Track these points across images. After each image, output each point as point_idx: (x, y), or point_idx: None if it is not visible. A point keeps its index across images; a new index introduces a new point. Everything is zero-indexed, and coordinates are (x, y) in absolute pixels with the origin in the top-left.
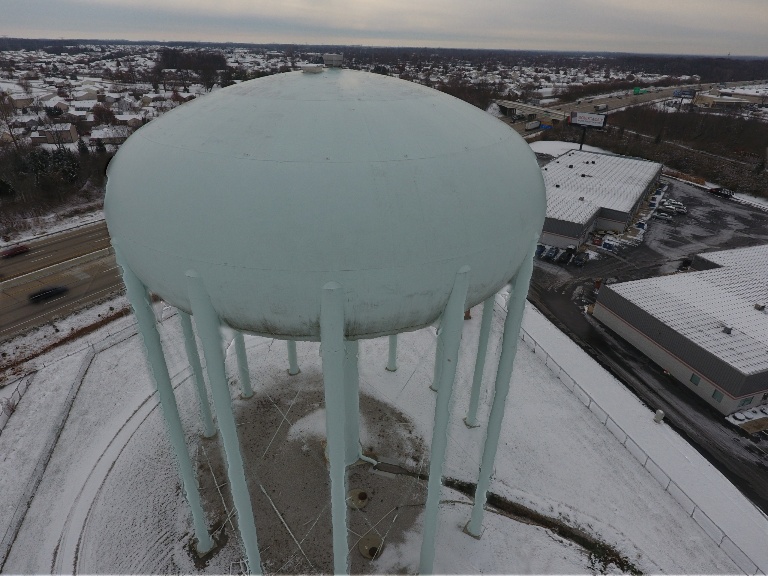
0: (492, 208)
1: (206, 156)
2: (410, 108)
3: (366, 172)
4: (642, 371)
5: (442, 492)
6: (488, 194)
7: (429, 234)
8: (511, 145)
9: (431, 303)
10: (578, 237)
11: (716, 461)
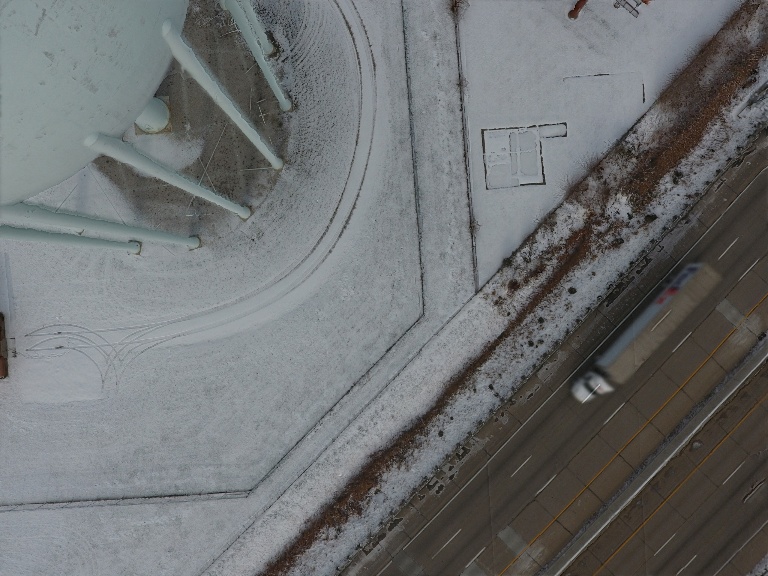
0: None
1: None
2: None
3: None
4: None
5: None
6: None
7: None
8: None
9: None
10: None
11: None
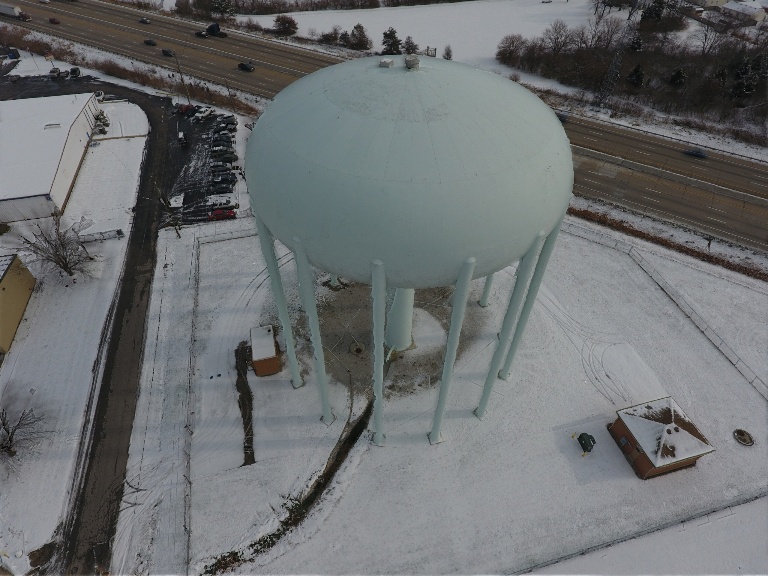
0: None
1: None
2: (322, 110)
3: None
4: None
5: (360, 401)
6: (268, 175)
7: None
8: (326, 174)
9: None
10: None
11: None
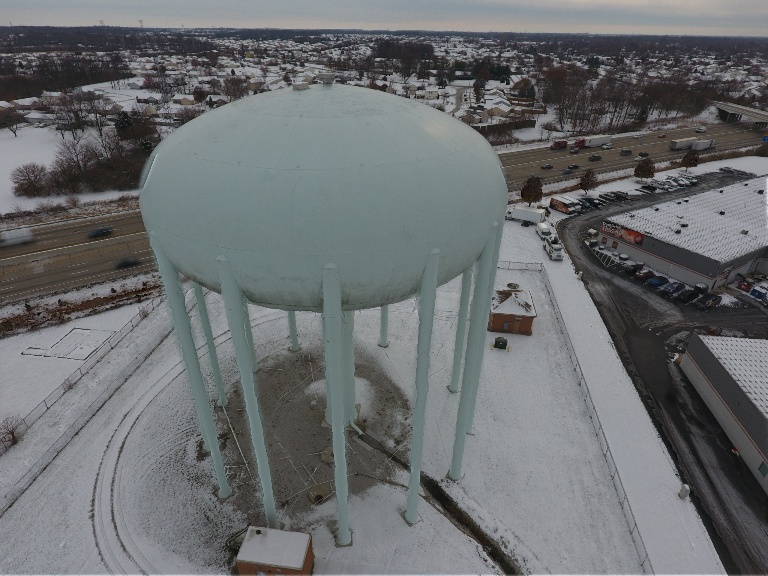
0: (365, 219)
1: (176, 152)
2: (338, 126)
3: (260, 176)
4: (702, 440)
5: (402, 476)
6: (365, 206)
7: (295, 231)
8: (429, 165)
9: (305, 289)
10: (712, 276)
11: (731, 563)
